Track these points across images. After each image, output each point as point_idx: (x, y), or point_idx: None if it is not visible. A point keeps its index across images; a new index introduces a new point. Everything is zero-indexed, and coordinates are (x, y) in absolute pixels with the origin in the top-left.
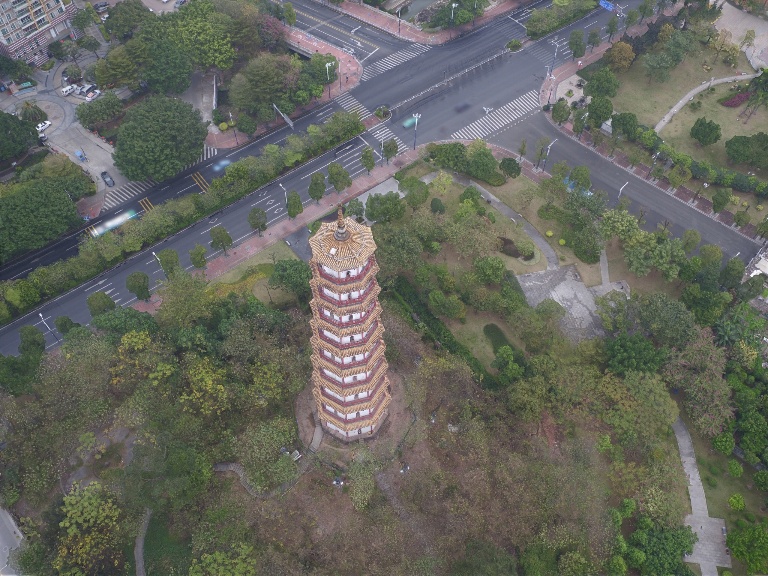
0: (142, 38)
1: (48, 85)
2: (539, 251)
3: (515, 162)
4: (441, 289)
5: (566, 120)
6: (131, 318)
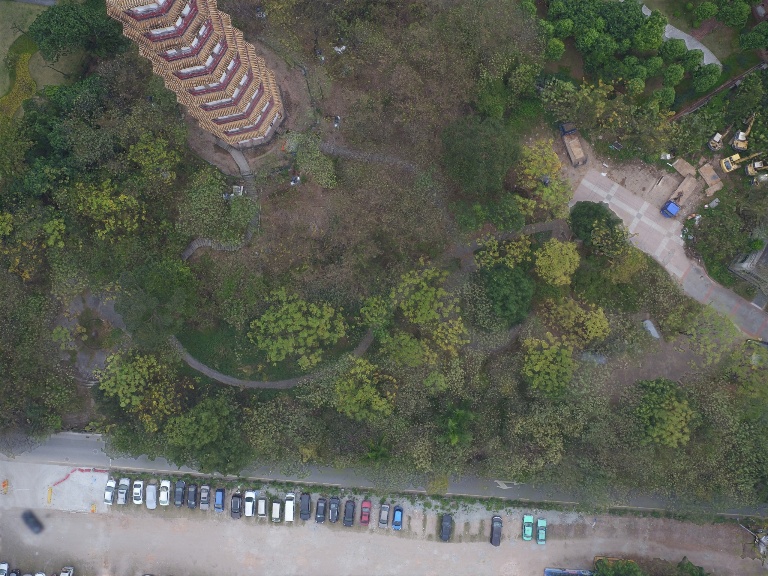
0: None
1: None
2: None
3: None
4: None
5: None
6: None
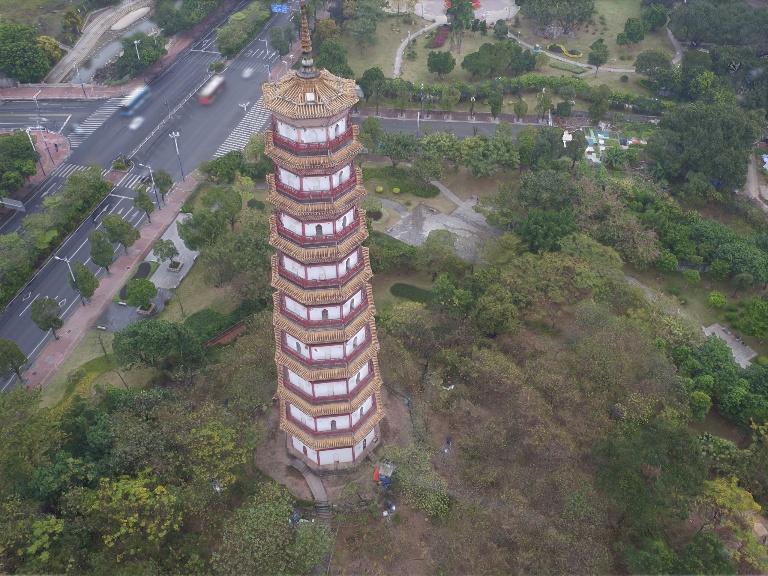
0: None
1: None
2: (382, 207)
3: None
4: None
5: None
6: None
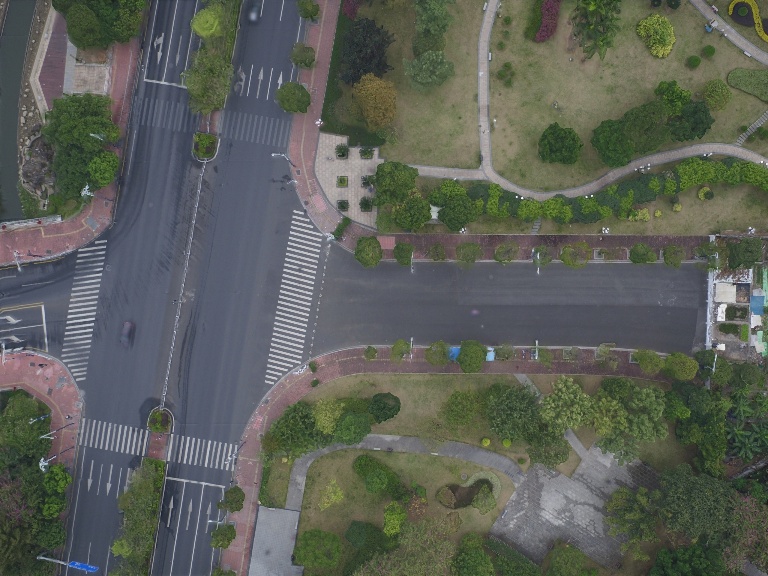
0: None
1: None
2: (491, 472)
3: (388, 405)
4: None
5: None
6: None
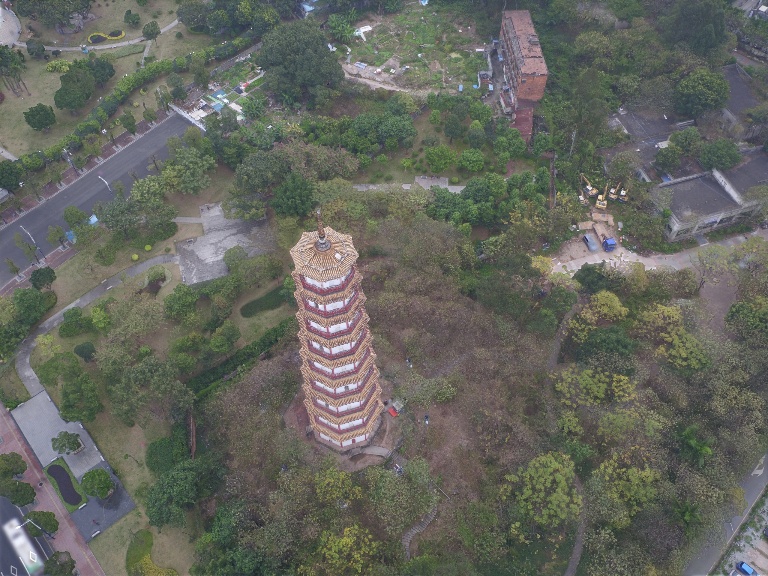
0: None
1: None
2: None
3: (40, 270)
4: None
5: None
6: None
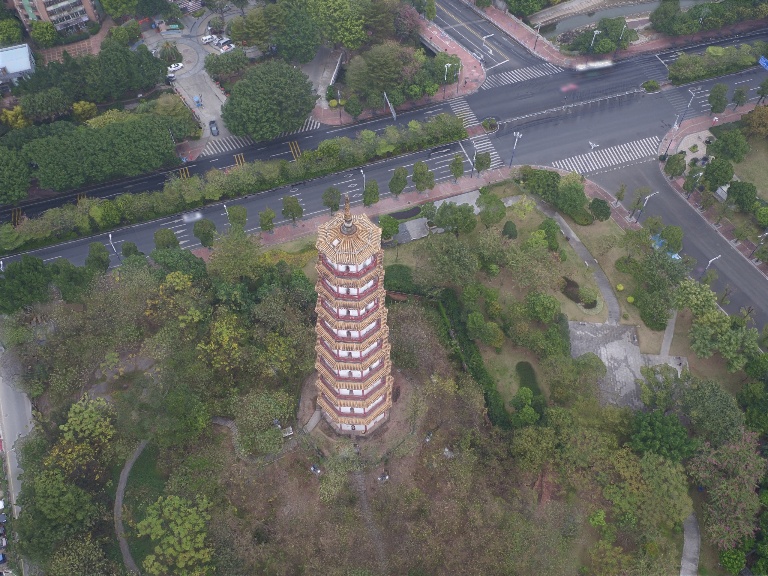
0: (283, 4)
1: (193, 31)
2: (603, 302)
3: (606, 205)
4: (486, 313)
5: (679, 175)
6: (183, 260)
